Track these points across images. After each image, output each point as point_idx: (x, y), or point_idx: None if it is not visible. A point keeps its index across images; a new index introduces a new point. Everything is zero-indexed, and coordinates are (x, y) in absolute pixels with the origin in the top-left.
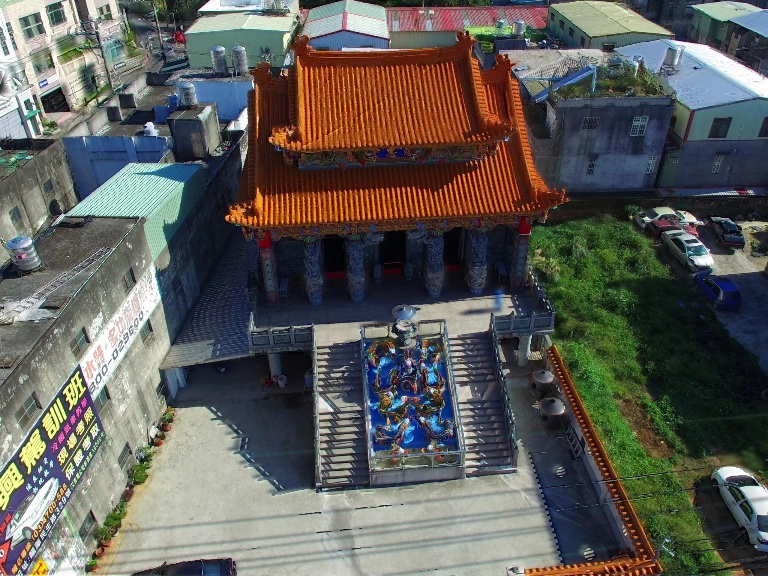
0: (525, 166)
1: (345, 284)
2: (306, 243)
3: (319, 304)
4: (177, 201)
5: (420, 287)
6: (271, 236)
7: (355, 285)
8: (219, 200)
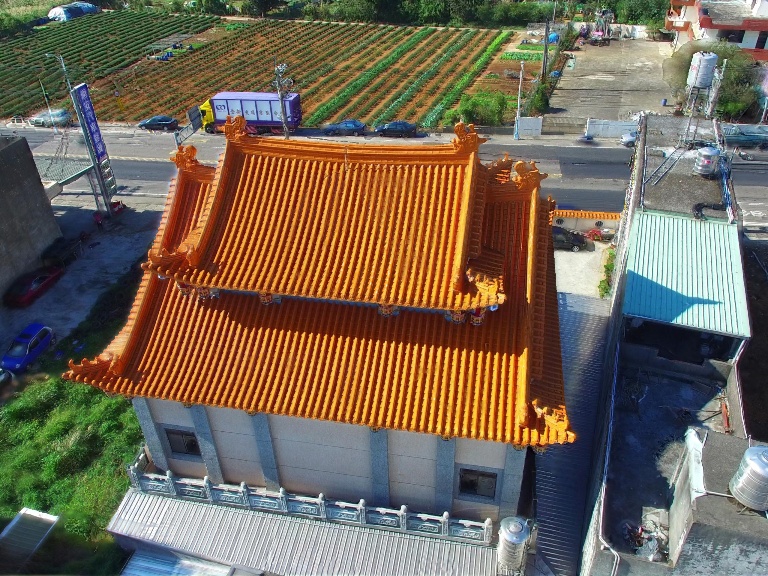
0: None
1: None
2: None
3: None
4: None
5: None
6: None
7: None
8: None
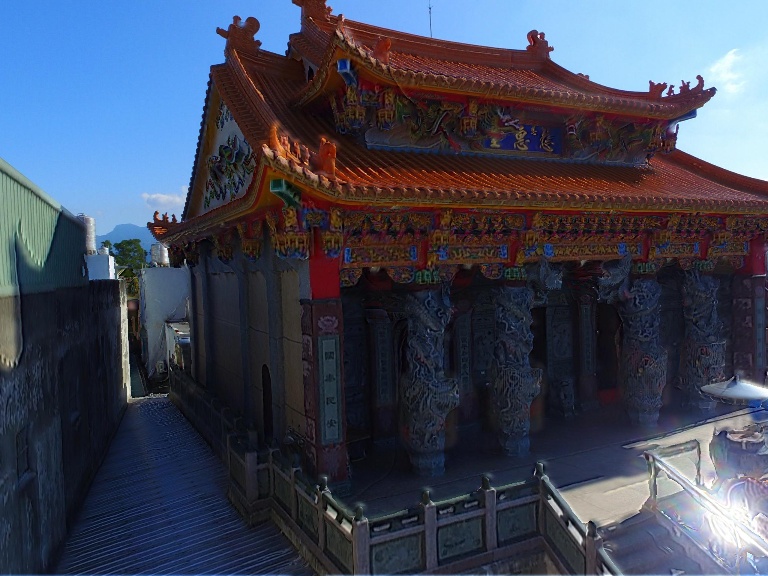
0: (717, 168)
1: (484, 417)
2: (423, 286)
3: (443, 473)
4: (46, 224)
5: (605, 420)
6: (342, 265)
7: (523, 402)
8: (98, 341)
